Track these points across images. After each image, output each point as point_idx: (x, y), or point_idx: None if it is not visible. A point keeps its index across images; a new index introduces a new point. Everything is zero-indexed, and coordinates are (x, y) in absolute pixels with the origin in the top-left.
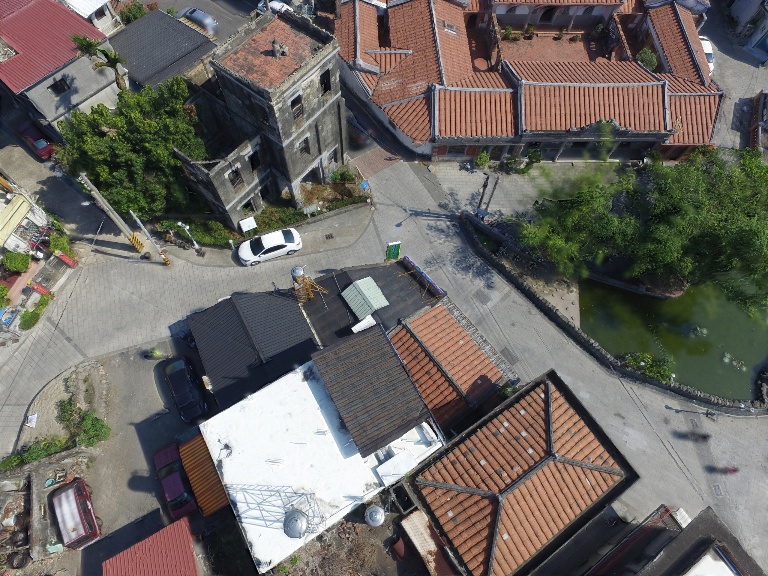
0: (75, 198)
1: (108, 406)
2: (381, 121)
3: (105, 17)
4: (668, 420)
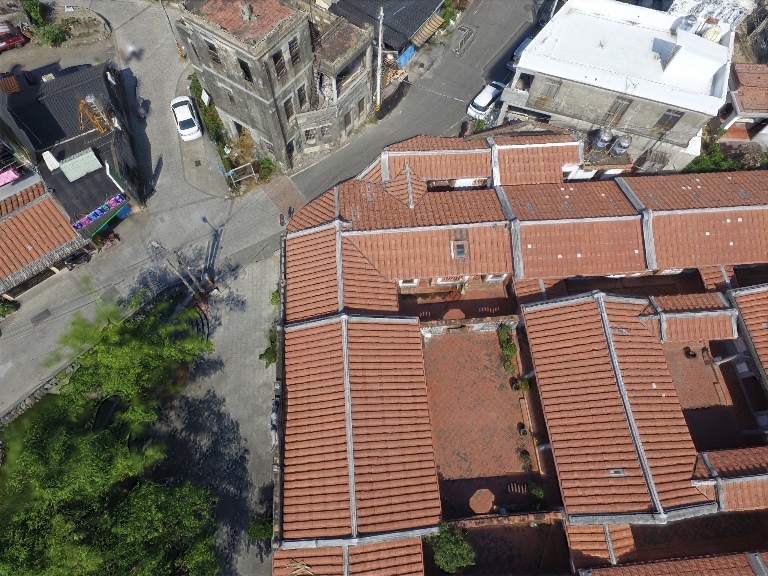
0: None
1: (76, 46)
2: None
3: None
4: None
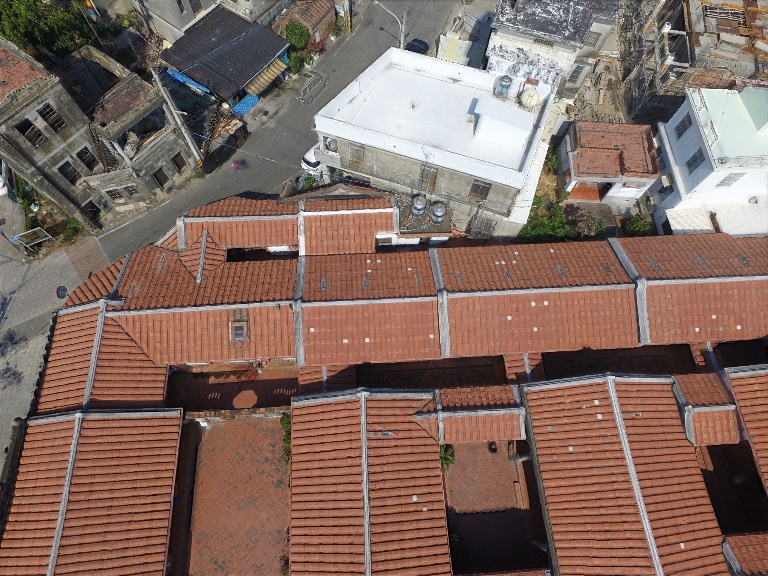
0: None
1: None
2: None
3: (248, 3)
4: None
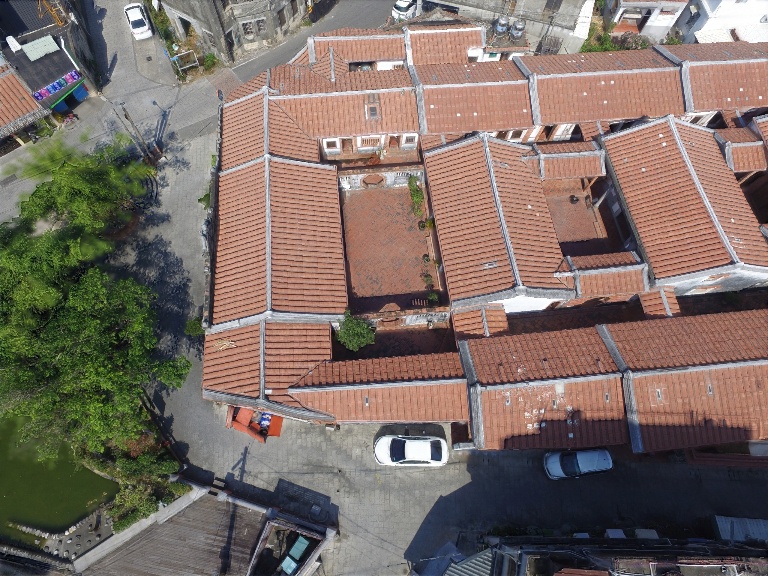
0: None
1: None
2: None
3: None
4: None
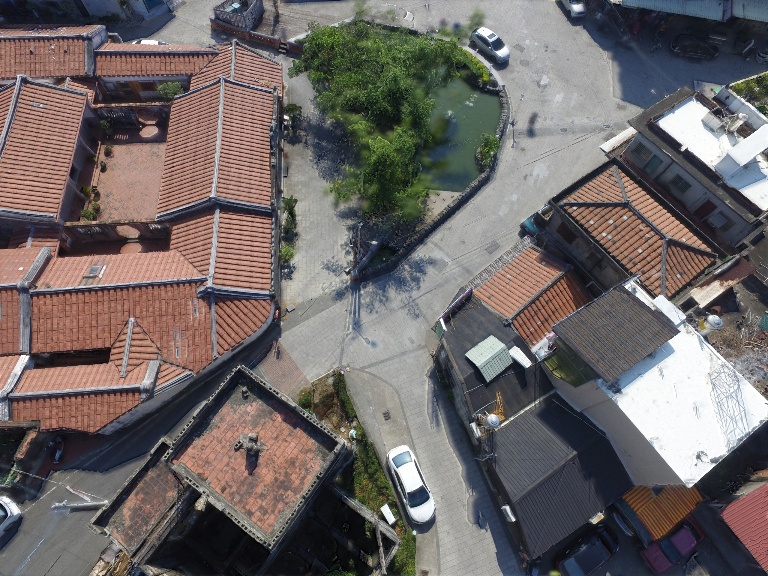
0: None
1: None
2: (221, 364)
3: None
4: (522, 148)
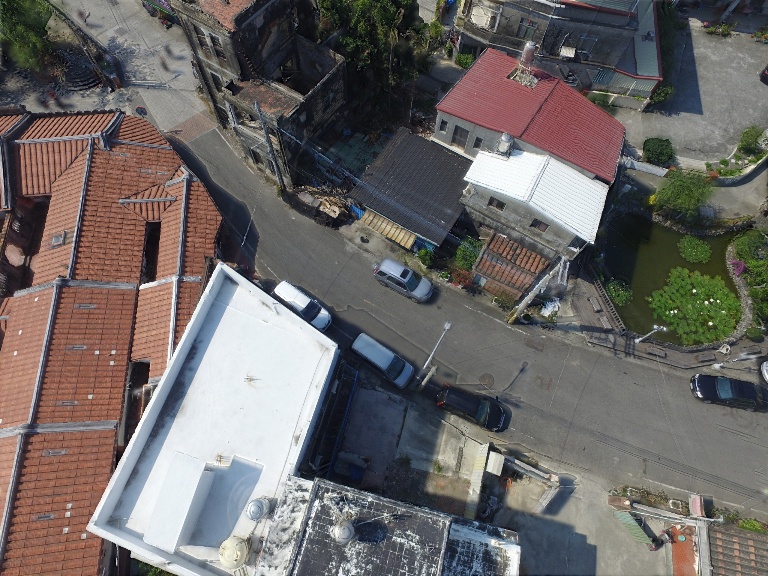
0: (452, 82)
1: None
2: None
3: None
4: None
